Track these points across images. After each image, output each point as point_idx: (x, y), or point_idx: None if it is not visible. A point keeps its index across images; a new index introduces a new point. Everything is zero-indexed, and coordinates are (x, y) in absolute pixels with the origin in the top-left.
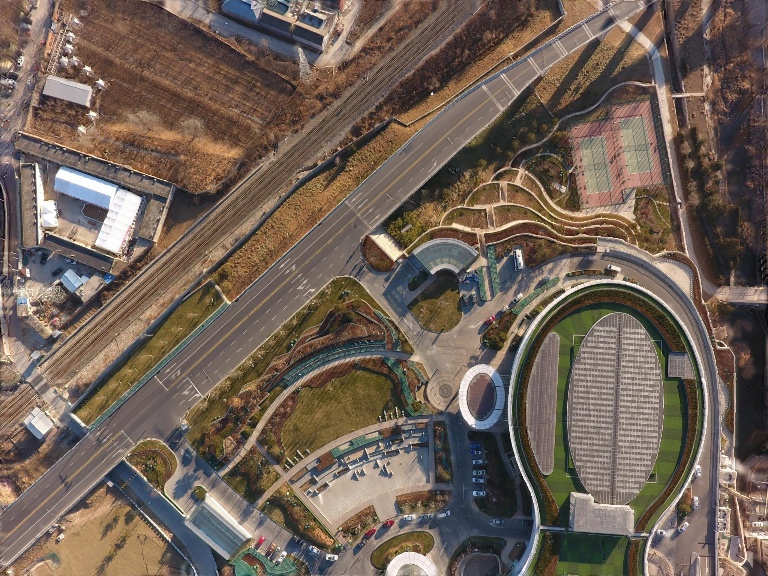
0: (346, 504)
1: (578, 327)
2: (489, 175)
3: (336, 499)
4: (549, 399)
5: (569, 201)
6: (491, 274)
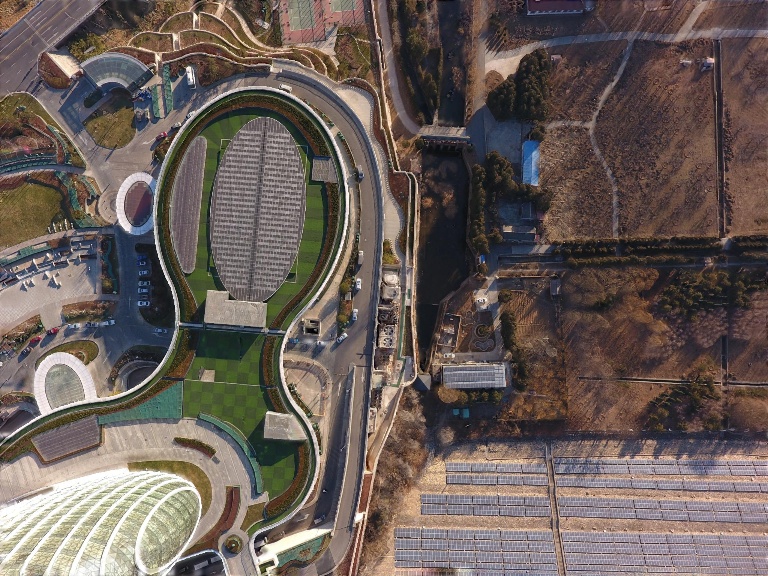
0: (14, 313)
1: (226, 132)
2: (188, 7)
3: (4, 309)
4: (193, 200)
5: (270, 37)
6: (165, 92)
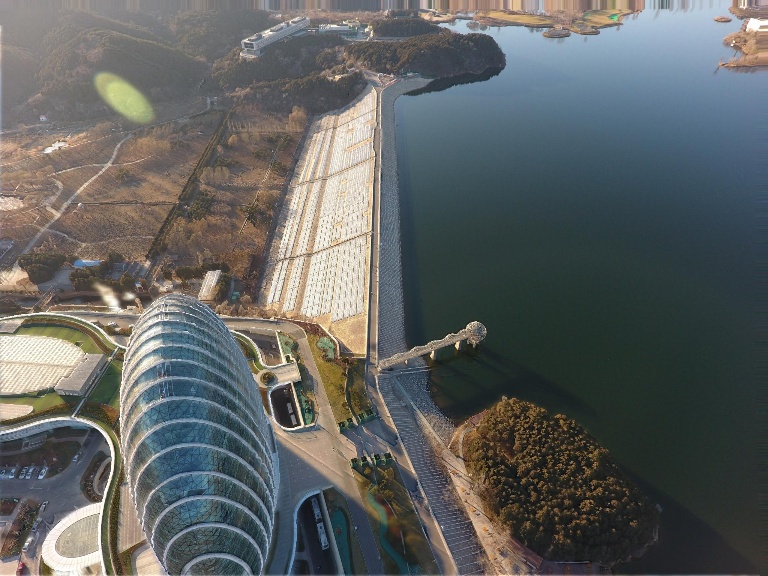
0: None
1: None
2: None
3: None
4: None
5: None
6: None
